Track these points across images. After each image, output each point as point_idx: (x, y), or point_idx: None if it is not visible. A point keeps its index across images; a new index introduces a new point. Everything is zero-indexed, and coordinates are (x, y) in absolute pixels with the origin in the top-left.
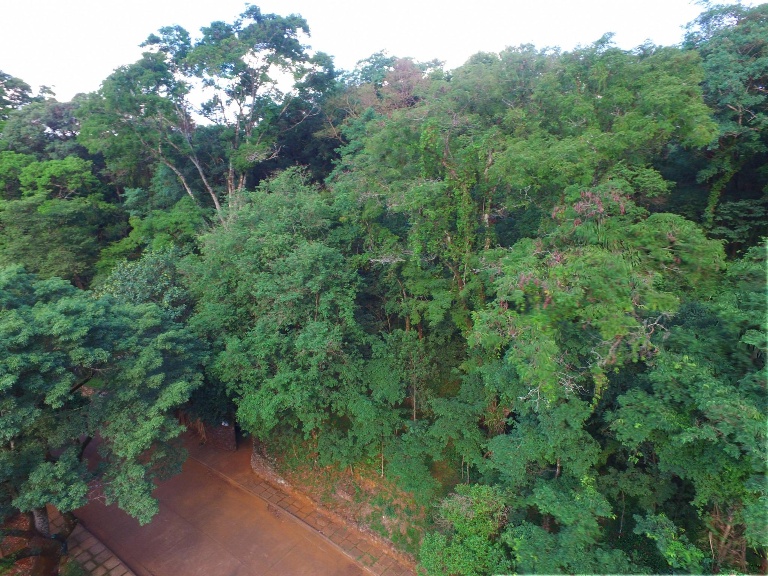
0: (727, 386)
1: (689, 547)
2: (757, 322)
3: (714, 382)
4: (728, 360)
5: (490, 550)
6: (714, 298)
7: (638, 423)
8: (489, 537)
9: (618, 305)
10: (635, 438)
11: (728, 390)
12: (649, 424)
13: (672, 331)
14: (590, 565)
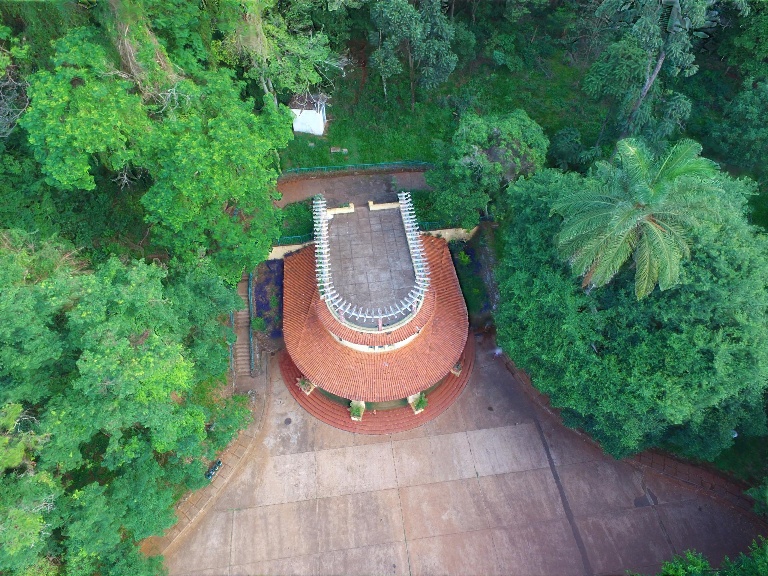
0: (90, 405)
1: (131, 443)
2: (49, 357)
3: (82, 409)
4: (43, 370)
5: (71, 575)
6: (1, 359)
7: (70, 454)
8: (59, 575)
9: (3, 448)
10: (78, 460)
11: (93, 406)
12: (73, 447)
13: (7, 397)
14: (120, 505)
